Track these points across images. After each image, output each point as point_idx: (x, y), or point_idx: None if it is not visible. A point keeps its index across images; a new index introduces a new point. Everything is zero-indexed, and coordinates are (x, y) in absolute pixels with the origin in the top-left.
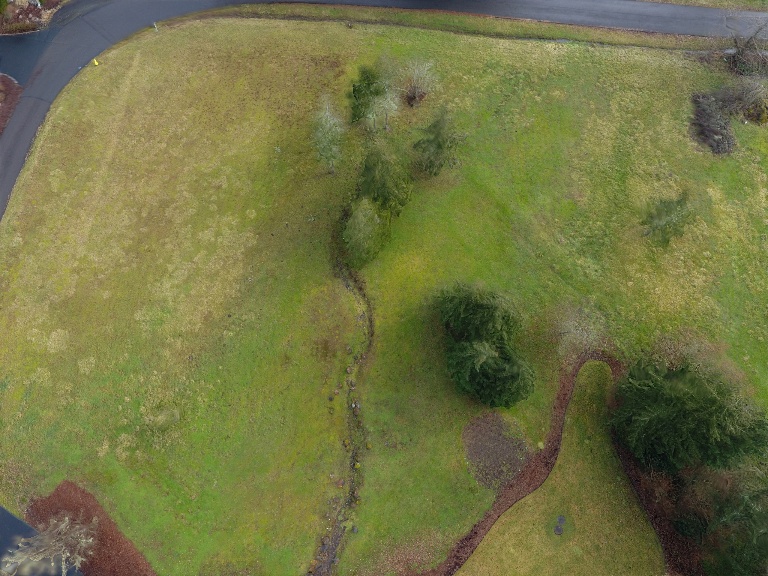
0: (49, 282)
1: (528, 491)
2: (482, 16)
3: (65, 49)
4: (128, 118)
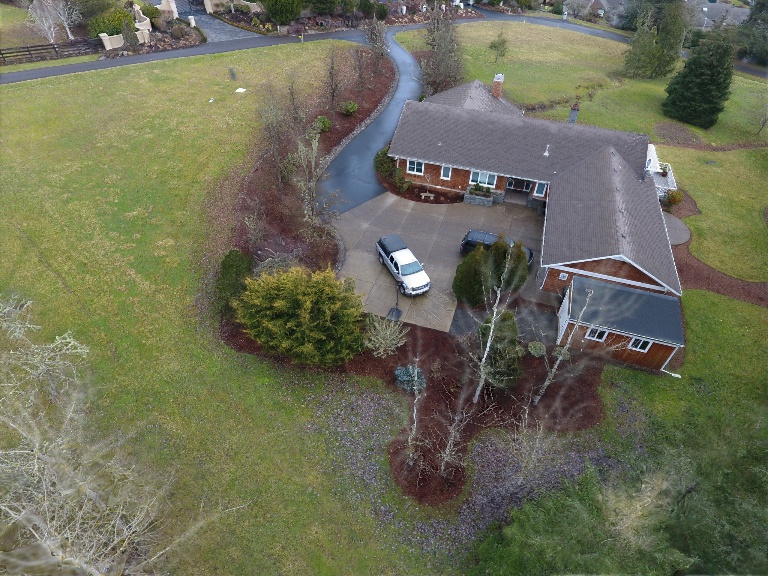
0: (465, 33)
1: (692, 148)
2: (760, 77)
3: (512, 19)
4: (529, 29)
